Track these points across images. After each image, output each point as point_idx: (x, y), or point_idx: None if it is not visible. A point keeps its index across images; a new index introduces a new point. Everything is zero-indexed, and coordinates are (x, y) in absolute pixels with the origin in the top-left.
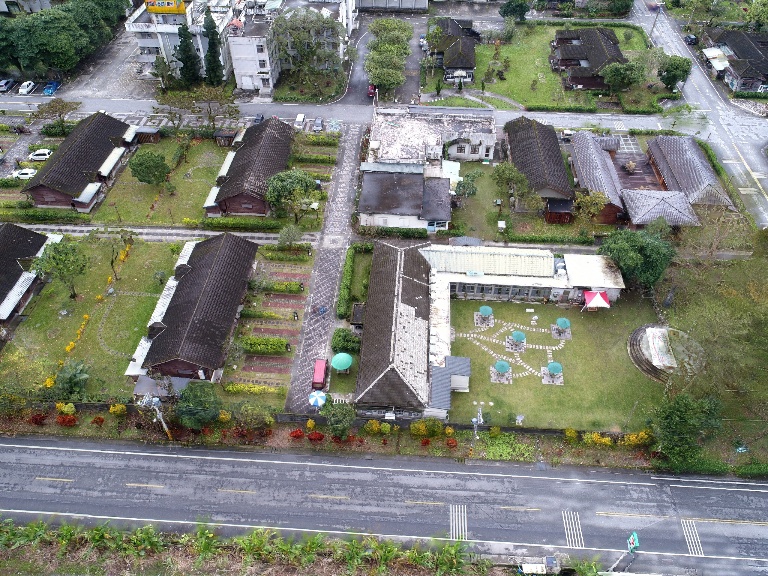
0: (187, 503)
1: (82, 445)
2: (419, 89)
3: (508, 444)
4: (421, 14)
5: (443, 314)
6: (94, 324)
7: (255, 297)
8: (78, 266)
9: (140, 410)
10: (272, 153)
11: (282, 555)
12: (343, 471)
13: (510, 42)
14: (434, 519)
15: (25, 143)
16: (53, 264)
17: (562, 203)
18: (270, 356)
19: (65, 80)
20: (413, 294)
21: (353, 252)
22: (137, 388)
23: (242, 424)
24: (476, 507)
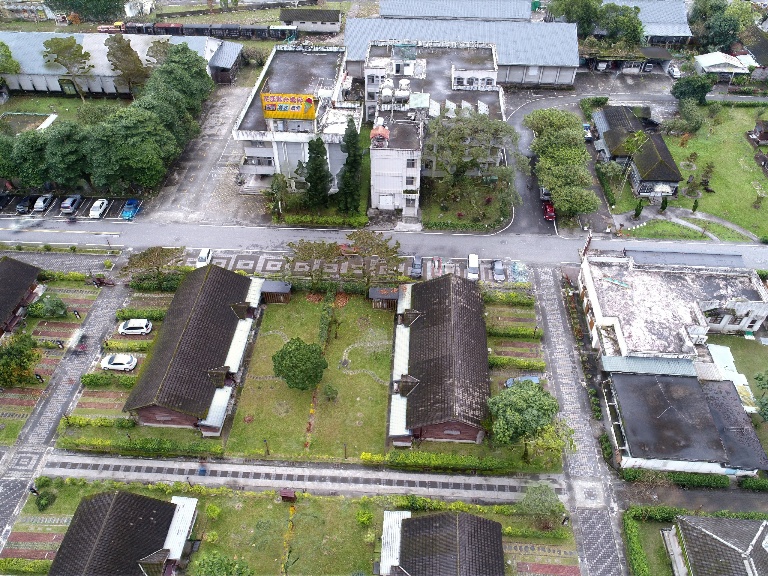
0: None
1: None
2: (608, 208)
3: None
4: (565, 91)
5: None
6: None
7: None
8: None
9: None
10: (468, 337)
11: None
12: None
13: (694, 133)
14: None
15: (109, 302)
16: None
17: None
18: None
19: (146, 195)
20: None
21: (637, 527)
22: None
23: None
24: None
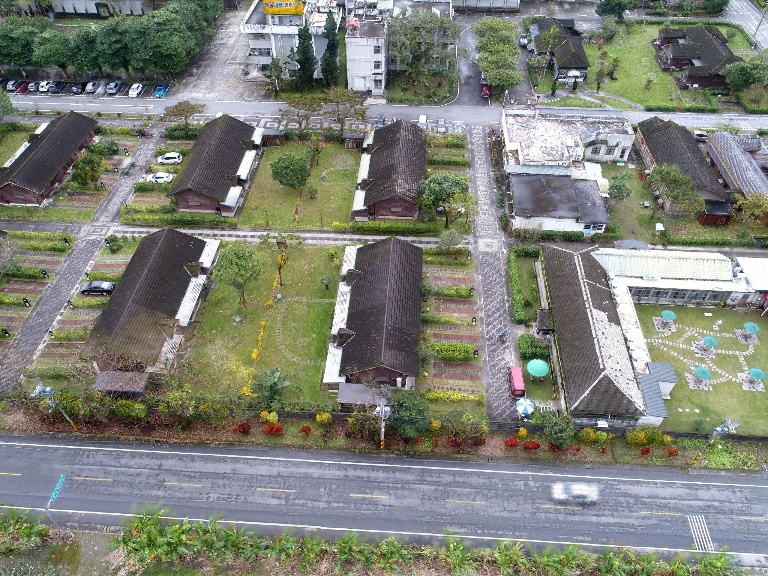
0: (418, 514)
1: (294, 455)
2: (532, 89)
3: (726, 452)
4: (512, 13)
5: (631, 319)
6: (271, 330)
7: (426, 302)
8: (255, 272)
9: (357, 419)
10: (411, 155)
11: (532, 568)
12: (567, 481)
13: (611, 41)
14: (675, 530)
15: (149, 146)
16: (236, 270)
17: (718, 205)
18: (457, 362)
19: (172, 82)
20: (600, 299)
21: None
22: (341, 396)
23: (455, 433)
24: (714, 517)
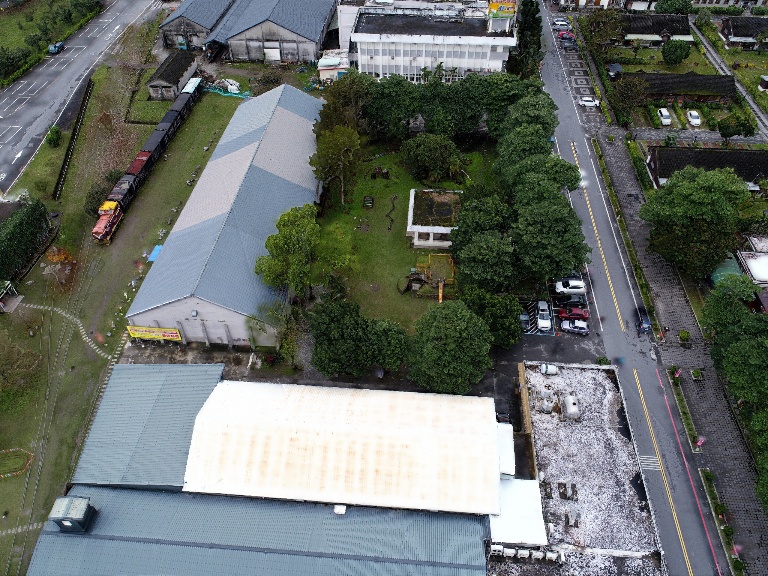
0: None
1: None
2: None
3: None
4: None
5: None
6: None
7: None
8: None
9: None
10: None
11: None
12: None
13: None
14: None
15: (645, 134)
16: None
17: None
18: None
19: None
20: None
21: None
22: None
23: None
24: None
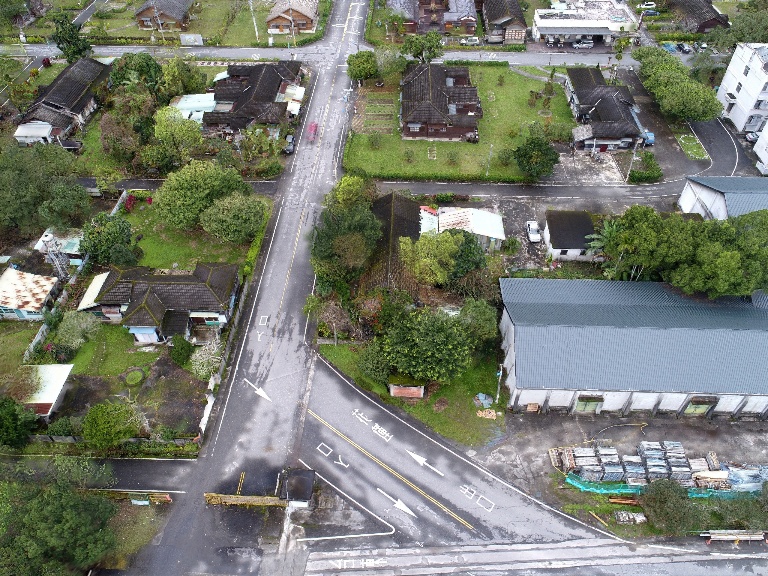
0: None
1: None
2: None
3: None
4: None
5: None
6: None
7: None
8: None
9: None
10: None
11: None
12: None
13: None
14: None
15: None
16: None
17: None
18: None
19: None
20: None
21: None
22: None
23: None
24: None
